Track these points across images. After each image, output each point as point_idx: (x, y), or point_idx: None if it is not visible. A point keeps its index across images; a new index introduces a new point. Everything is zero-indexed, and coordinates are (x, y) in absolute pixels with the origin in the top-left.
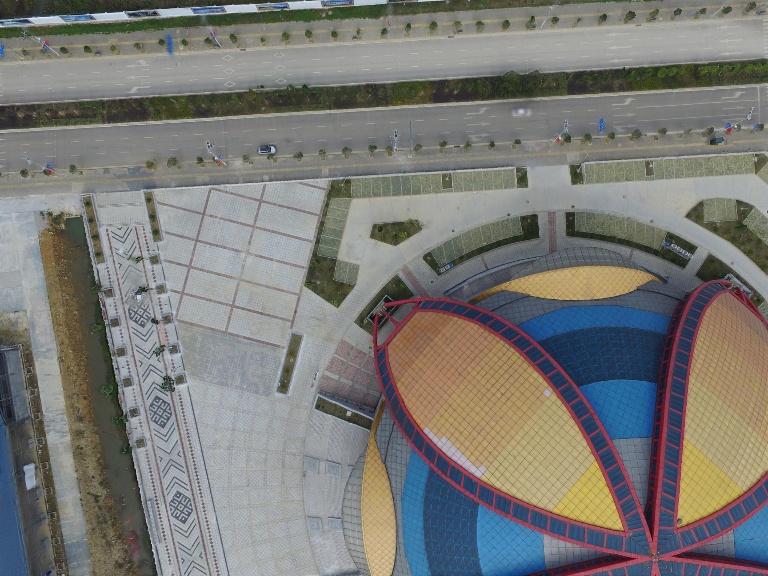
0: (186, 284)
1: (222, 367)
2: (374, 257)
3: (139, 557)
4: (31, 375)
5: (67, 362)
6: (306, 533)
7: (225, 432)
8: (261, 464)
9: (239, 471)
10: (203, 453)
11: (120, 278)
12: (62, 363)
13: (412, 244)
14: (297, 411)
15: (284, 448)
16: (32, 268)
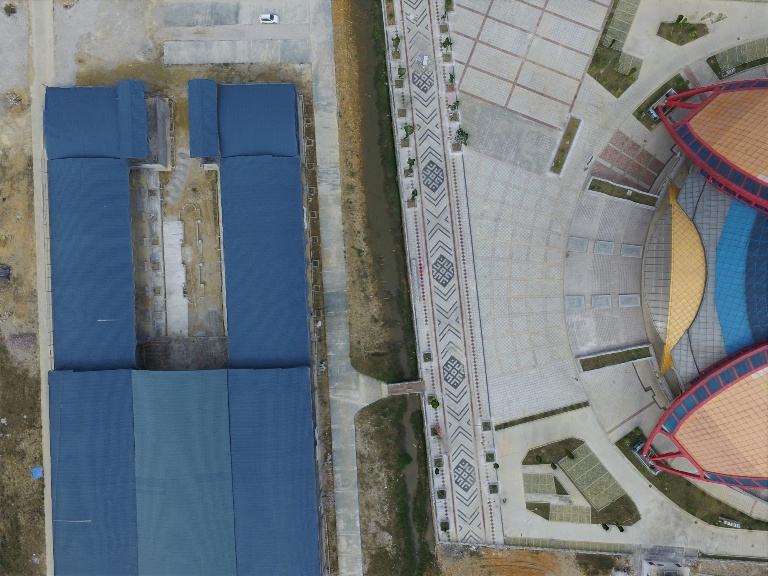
0: (471, 57)
1: (498, 141)
2: (658, 54)
3: (392, 317)
4: (309, 126)
5: (345, 118)
6: (563, 312)
7: (494, 204)
8: (526, 239)
9: (504, 243)
10: (470, 221)
11: (407, 43)
12: (340, 118)
13: (697, 46)
14: (567, 193)
15: (550, 227)
16: (322, 23)
